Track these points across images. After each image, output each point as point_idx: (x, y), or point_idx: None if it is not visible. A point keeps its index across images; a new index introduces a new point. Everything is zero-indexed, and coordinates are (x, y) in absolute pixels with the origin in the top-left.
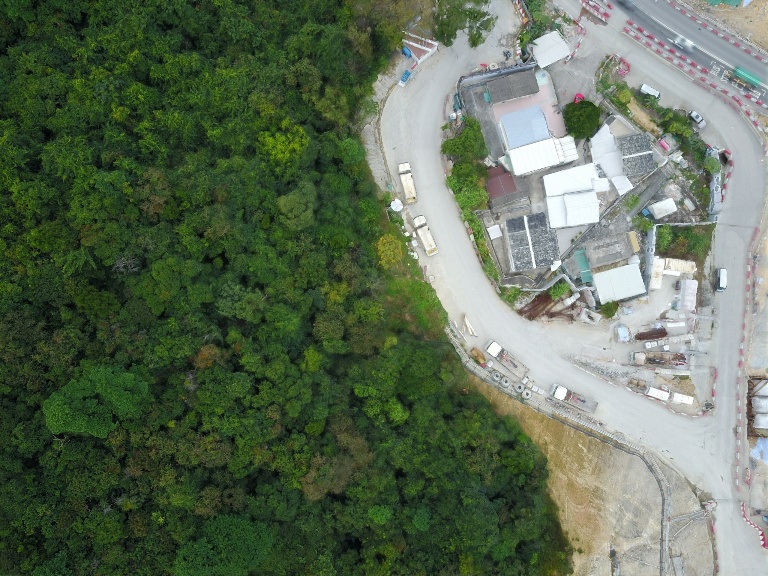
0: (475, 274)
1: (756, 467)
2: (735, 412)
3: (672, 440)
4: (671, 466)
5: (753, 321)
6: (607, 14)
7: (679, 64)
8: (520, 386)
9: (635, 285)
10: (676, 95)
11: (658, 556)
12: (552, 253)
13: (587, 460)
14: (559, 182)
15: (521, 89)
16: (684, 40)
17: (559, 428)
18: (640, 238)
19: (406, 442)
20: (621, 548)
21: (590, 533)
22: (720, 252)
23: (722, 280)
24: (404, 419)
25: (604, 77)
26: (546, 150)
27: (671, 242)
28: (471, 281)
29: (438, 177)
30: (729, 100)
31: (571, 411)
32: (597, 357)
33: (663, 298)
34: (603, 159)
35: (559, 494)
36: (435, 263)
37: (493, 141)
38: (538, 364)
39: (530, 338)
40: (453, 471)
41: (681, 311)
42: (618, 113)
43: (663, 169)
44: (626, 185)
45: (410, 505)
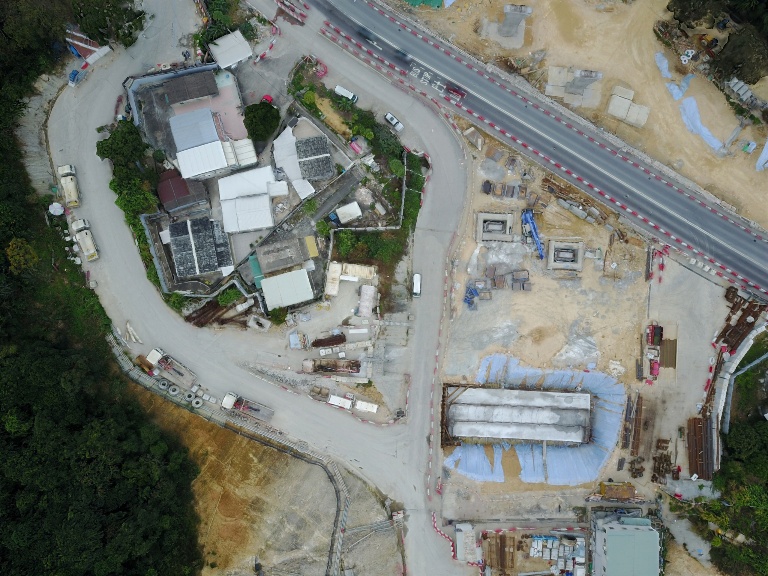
0: (140, 280)
1: (449, 476)
2: (429, 420)
3: (361, 449)
4: (360, 476)
5: (449, 327)
6: (302, 14)
7: (376, 65)
8: (190, 395)
9: (302, 291)
10: (375, 97)
11: (324, 569)
12: (223, 258)
13: (255, 470)
14: (233, 185)
15: (197, 90)
16: (383, 41)
17: (230, 438)
18: (324, 243)
19: (25, 454)
20: (270, 561)
21: (233, 546)
22: (419, 257)
23: (415, 285)
24: (25, 430)
25: (297, 78)
26: (214, 152)
27: (351, 247)
28: (136, 287)
29: (106, 180)
30: (429, 102)
31: (248, 420)
32: (272, 365)
33: (346, 304)
34: (285, 162)
35: (207, 506)
36: (99, 268)
37: (174, 143)
38: (212, 372)
39: (201, 345)
40: (68, 484)
41: (364, 317)
42: (309, 115)
43: (355, 172)
44: (307, 188)
45: (20, 519)
